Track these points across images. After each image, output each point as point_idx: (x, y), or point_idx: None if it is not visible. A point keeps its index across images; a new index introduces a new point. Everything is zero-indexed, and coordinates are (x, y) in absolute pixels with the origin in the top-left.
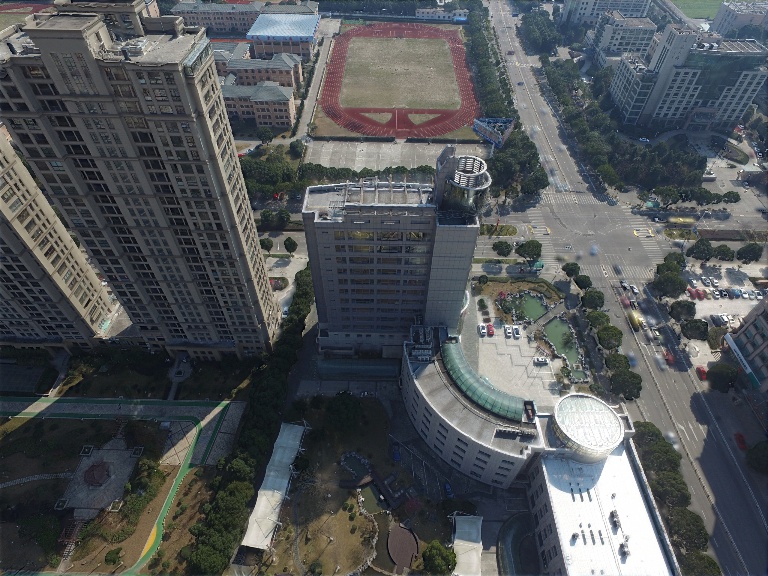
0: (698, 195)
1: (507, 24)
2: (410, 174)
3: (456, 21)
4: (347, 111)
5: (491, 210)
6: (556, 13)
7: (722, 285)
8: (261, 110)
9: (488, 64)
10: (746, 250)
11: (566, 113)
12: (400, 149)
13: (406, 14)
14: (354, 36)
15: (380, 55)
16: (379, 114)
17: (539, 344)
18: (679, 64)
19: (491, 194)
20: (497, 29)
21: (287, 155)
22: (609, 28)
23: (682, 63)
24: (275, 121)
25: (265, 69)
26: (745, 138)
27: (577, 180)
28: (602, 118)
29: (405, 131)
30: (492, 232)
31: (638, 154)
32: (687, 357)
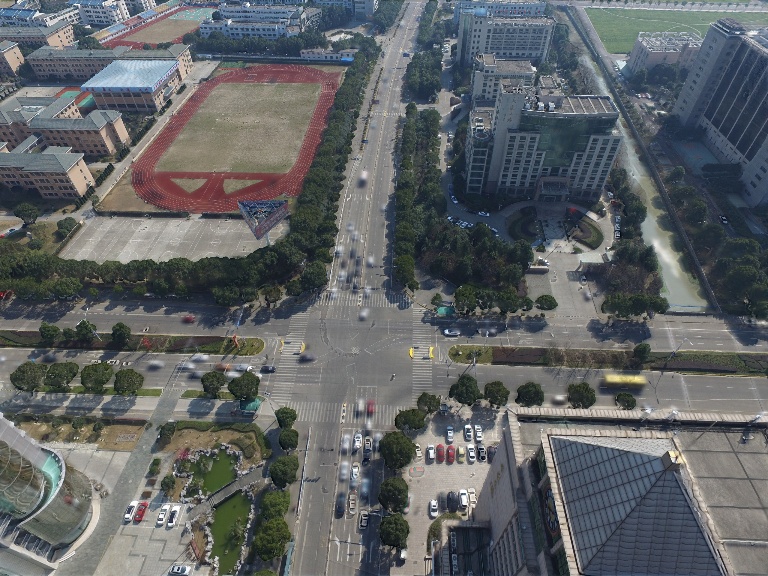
0: (500, 301)
1: (399, 64)
2: (156, 270)
3: (342, 62)
4: (158, 176)
5: (248, 316)
6: (452, 52)
7: (488, 439)
8: (40, 181)
9: (339, 117)
10: (521, 392)
11: (398, 180)
12: (188, 227)
13: (291, 55)
14: (223, 81)
15: (237, 104)
16: (192, 180)
17: (193, 538)
18: (514, 127)
19: (243, 298)
20: (385, 70)
21: (52, 236)
22: (478, 74)
23: (517, 126)
24: (60, 192)
25: (70, 129)
26: (610, 210)
27: (377, 271)
28: (431, 189)
29: (208, 203)
30: (230, 350)
31: (449, 240)
32: (388, 566)
